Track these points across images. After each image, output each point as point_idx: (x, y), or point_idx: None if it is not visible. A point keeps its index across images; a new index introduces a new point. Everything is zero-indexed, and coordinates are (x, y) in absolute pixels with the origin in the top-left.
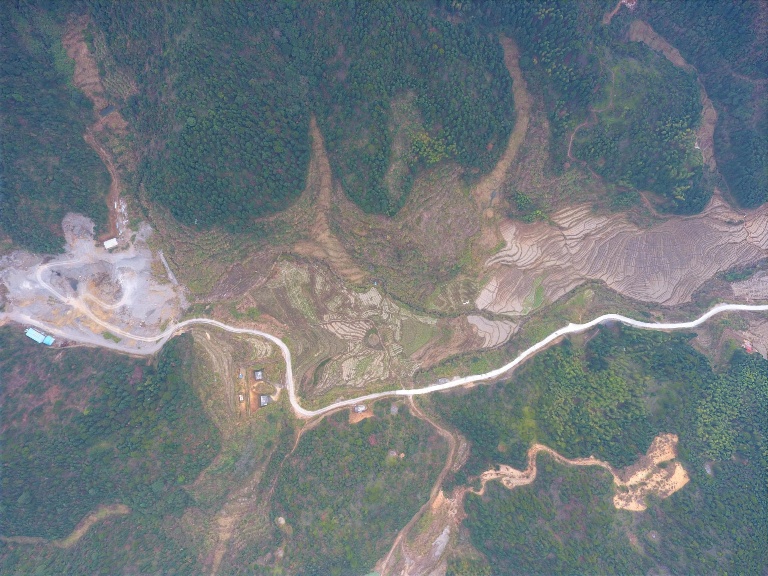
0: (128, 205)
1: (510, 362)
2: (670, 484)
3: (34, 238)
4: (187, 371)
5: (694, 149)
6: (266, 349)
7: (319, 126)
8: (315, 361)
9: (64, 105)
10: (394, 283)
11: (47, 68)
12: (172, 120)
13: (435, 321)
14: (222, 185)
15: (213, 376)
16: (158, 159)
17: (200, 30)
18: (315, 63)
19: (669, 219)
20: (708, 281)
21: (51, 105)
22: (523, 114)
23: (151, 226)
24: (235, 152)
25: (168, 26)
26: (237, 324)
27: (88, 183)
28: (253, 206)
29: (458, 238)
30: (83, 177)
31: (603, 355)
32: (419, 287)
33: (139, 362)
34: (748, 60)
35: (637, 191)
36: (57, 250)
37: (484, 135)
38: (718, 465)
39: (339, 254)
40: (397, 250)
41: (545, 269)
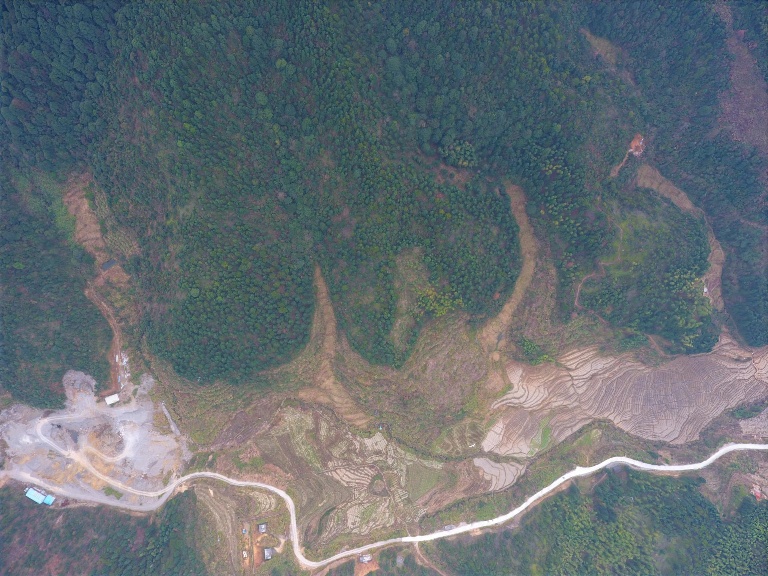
0: (130, 359)
1: (517, 508)
2: None
3: (34, 398)
4: (190, 534)
5: (702, 297)
6: (270, 502)
7: (324, 276)
8: (320, 511)
9: (65, 262)
10: (399, 428)
11: (48, 225)
12: (175, 286)
13: (441, 465)
14: (226, 347)
15: (216, 536)
16: (161, 321)
17: (204, 204)
18: (320, 219)
19: (677, 357)
20: (716, 418)
21: (52, 266)
22: (530, 258)
23: (153, 377)
24: (239, 318)
25: (171, 198)
26: (240, 476)
27: (89, 343)
28: (257, 364)
29: (464, 383)
30: (84, 338)
31: (611, 504)
32: (425, 432)
33: (141, 524)
34: (756, 209)
35: (645, 335)
36: (58, 407)
37: (491, 287)
38: None
39: (344, 400)
40: (403, 399)
41: (552, 409)
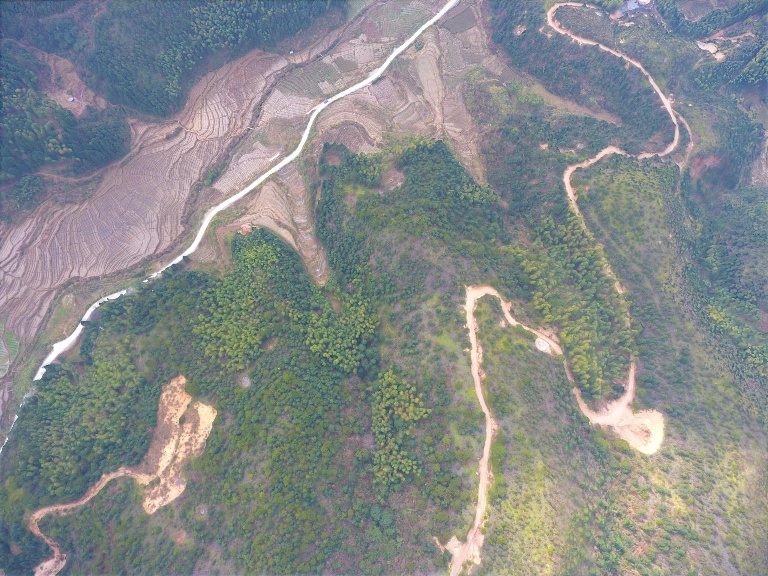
0: None
1: (6, 438)
2: (202, 434)
3: None
4: None
5: None
6: None
7: None
8: None
9: None
10: None
11: None
12: None
13: None
14: None
15: None
16: None
17: None
18: None
19: (102, 175)
20: (189, 200)
21: None
22: None
23: None
24: None
25: None
26: None
27: None
28: None
29: None
30: None
31: (89, 352)
32: None
33: None
34: (34, 0)
35: (27, 175)
36: None
37: None
38: (251, 369)
39: None
40: None
41: None
